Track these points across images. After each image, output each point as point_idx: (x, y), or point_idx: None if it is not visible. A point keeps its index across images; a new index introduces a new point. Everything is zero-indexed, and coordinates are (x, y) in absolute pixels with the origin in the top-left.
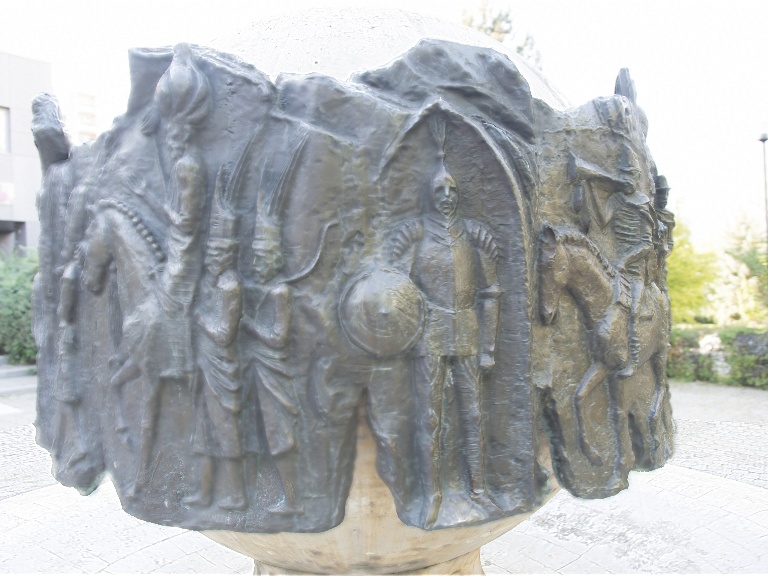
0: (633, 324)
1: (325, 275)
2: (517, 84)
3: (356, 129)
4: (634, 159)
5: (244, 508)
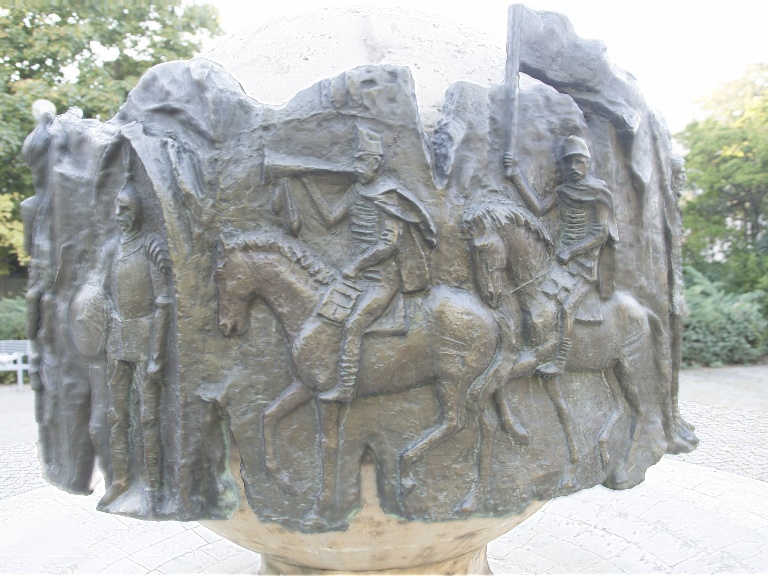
0: (346, 340)
1: (65, 287)
2: (202, 91)
3: (86, 162)
4: (367, 141)
5: (45, 464)
